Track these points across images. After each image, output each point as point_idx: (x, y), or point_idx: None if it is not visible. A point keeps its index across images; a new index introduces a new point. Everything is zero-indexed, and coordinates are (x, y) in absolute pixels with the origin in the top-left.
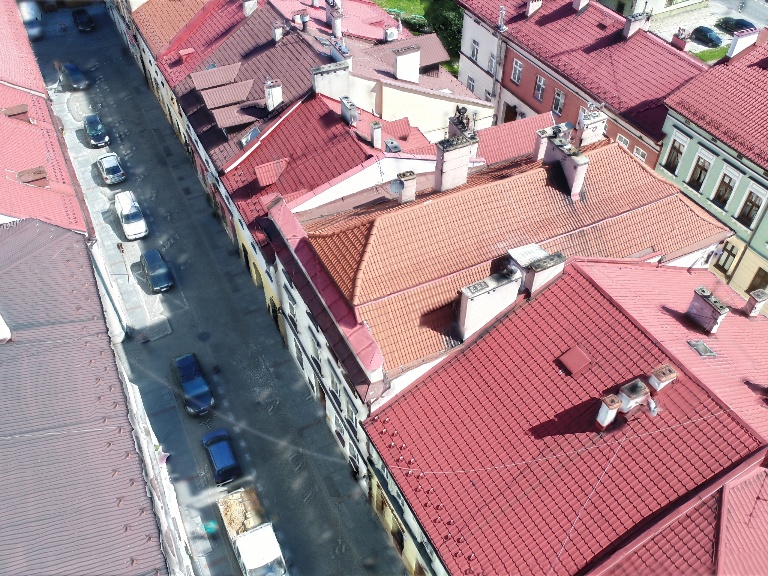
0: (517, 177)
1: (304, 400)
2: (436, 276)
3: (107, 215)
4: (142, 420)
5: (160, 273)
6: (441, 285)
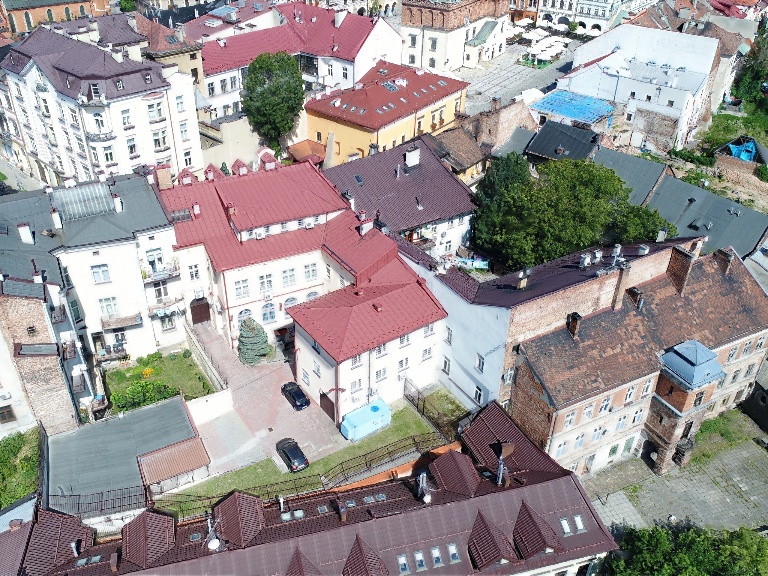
0: None
1: None
2: None
3: None
4: (651, 3)
5: None
6: None
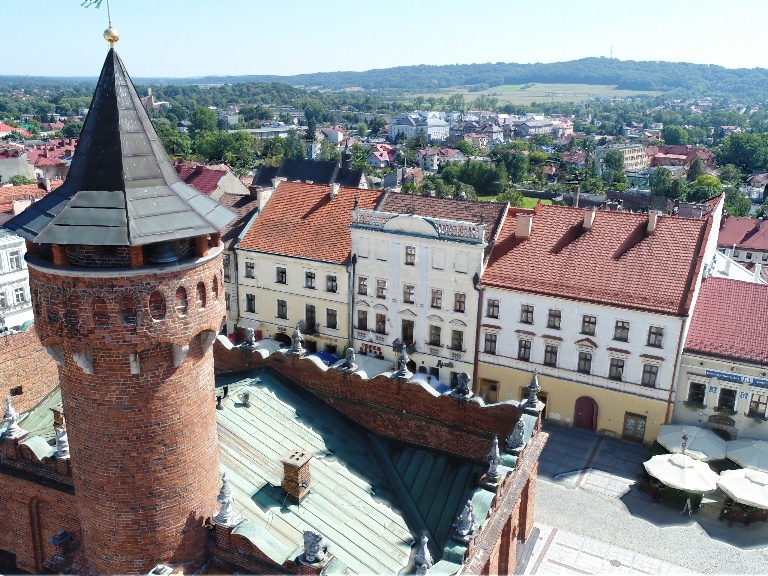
0: (28, 185)
1: None
2: (4, 203)
3: None
4: None
5: None
6: (6, 206)
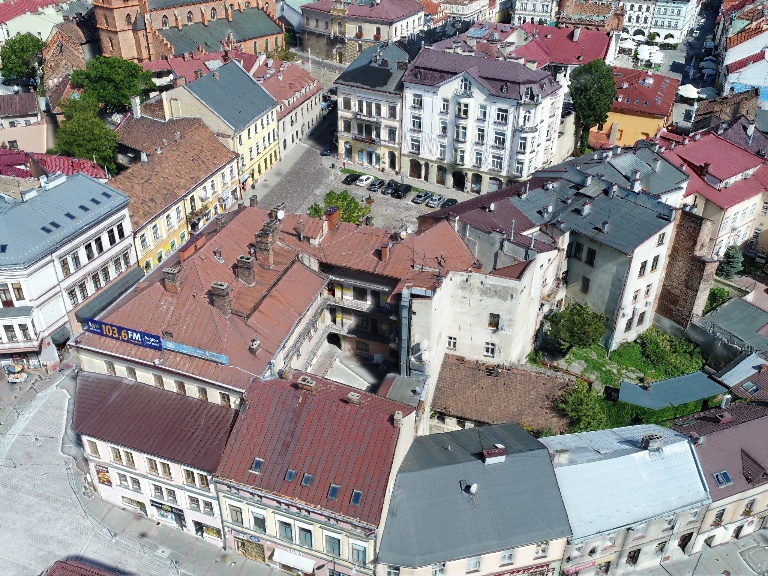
0: None
1: None
2: None
3: (698, 24)
4: None
5: None
6: None
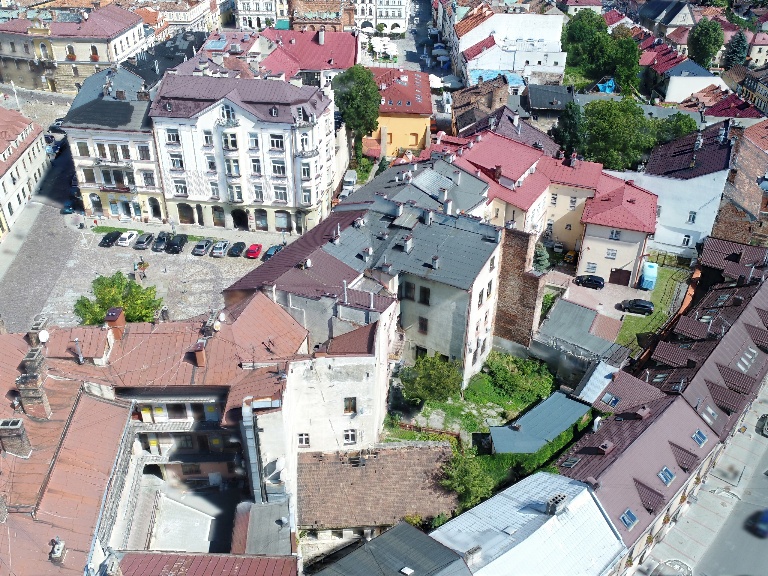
0: None
1: (431, 20)
2: None
3: None
4: None
5: (419, 12)
6: None
